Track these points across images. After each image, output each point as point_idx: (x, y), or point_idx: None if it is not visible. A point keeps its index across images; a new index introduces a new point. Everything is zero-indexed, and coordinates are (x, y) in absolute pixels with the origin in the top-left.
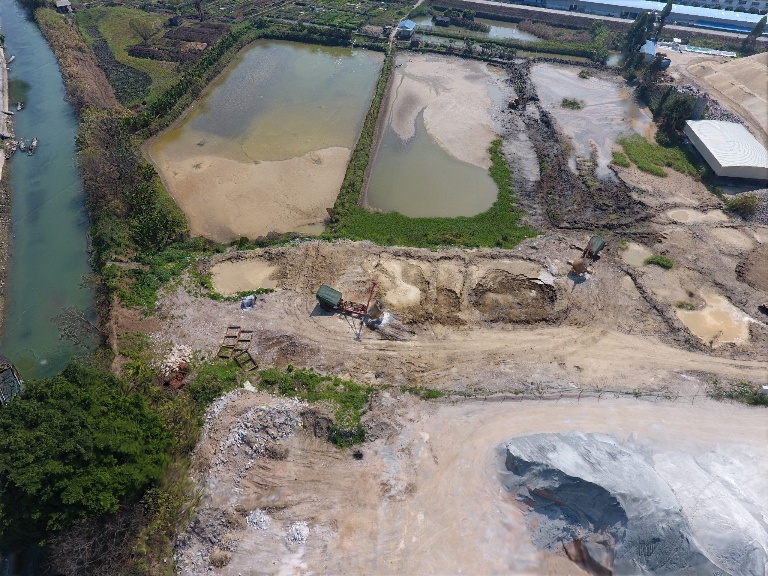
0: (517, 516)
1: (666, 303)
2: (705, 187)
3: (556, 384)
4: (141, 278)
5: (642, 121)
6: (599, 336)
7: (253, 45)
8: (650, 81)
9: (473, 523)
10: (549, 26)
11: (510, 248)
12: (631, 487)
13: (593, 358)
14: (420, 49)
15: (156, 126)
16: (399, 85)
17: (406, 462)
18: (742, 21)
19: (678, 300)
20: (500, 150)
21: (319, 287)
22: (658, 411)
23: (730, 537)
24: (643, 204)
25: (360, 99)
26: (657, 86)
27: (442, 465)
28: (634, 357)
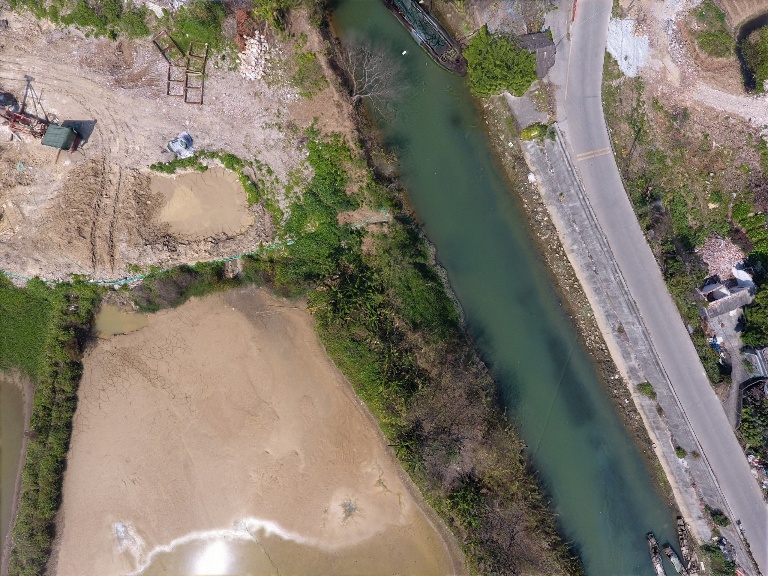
0: None
1: None
2: None
3: None
4: (338, 193)
5: None
6: None
7: None
8: None
9: None
10: None
11: None
12: None
13: None
14: None
15: None
16: None
17: None
18: None
19: None
20: None
21: (84, 170)
22: None
23: None
24: None
25: None
26: None
27: None
28: None
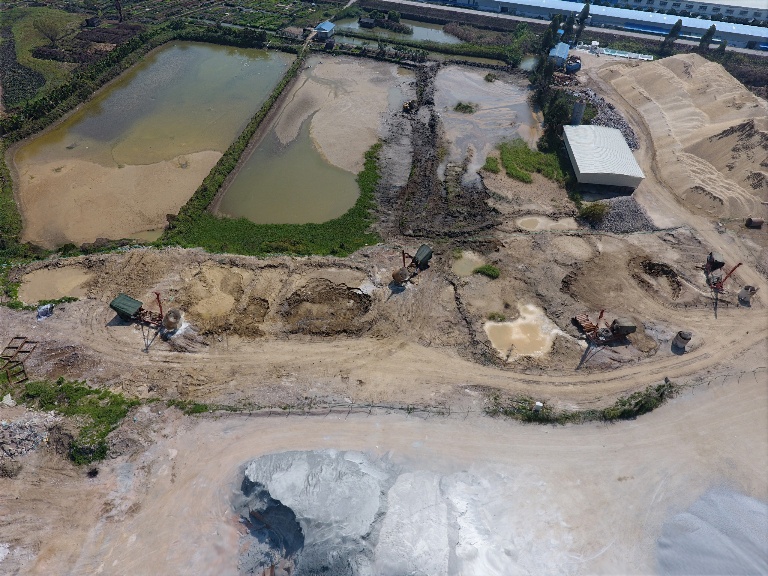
0: (233, 539)
1: (477, 314)
2: (567, 194)
3: (331, 399)
4: None
5: (530, 126)
6: (396, 348)
7: (166, 46)
8: (545, 85)
9: (184, 546)
10: (475, 28)
11: (343, 256)
12: (322, 511)
13: (380, 372)
14: (334, 51)
15: (28, 129)
16: (299, 88)
17: (141, 480)
18: (668, 24)
19: (491, 311)
20: (377, 155)
21: None
22: (425, 428)
23: (398, 566)
24: (496, 211)
25: (253, 102)
26: (554, 90)
27: (177, 484)
28: (424, 371)
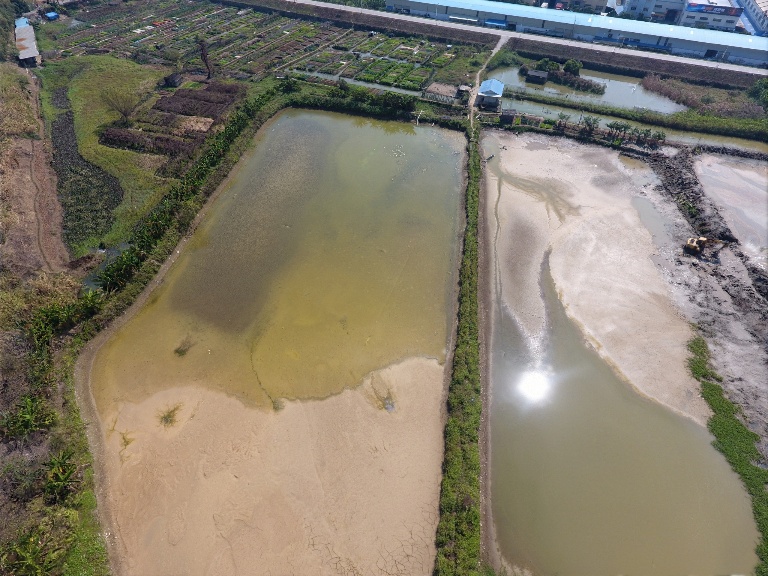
0: None
1: None
2: None
3: None
4: None
5: None
6: None
7: (277, 119)
8: None
9: None
10: (686, 83)
11: None
12: None
13: None
14: (515, 127)
15: (109, 311)
16: (497, 199)
17: None
18: None
19: None
20: (710, 368)
21: None
22: None
23: None
24: None
25: (442, 232)
26: None
27: None
28: None
